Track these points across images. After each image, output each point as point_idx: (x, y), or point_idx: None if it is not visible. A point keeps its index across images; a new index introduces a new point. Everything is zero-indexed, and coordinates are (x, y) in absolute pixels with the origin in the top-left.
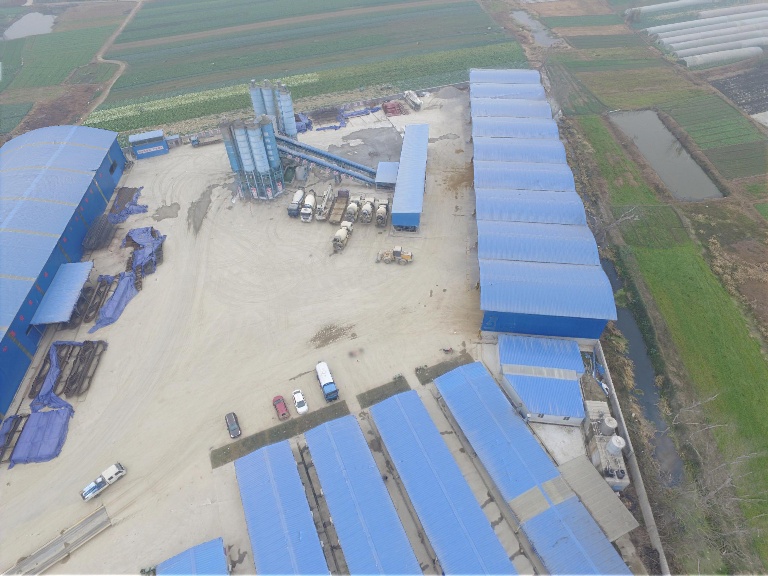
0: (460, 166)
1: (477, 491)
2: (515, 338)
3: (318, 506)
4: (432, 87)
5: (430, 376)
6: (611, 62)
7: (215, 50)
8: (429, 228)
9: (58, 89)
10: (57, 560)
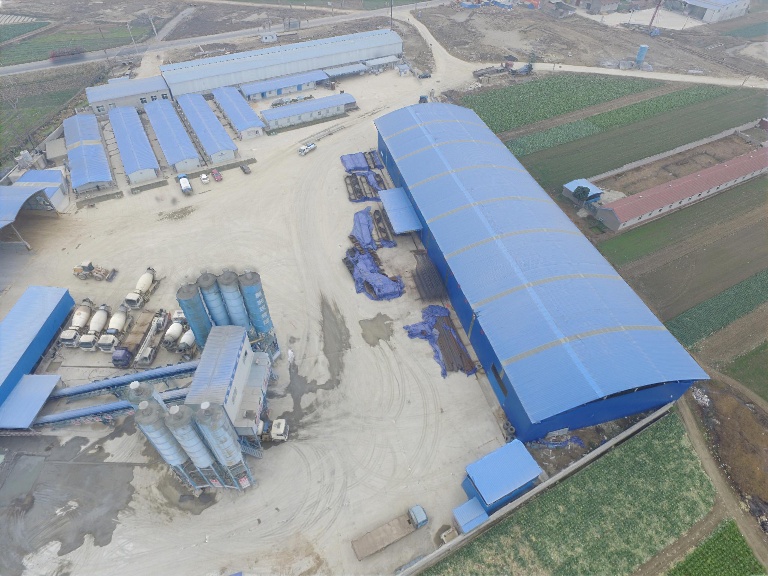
0: None
1: (116, 157)
2: None
3: (199, 151)
4: None
5: (114, 195)
6: None
7: None
8: None
9: None
10: None
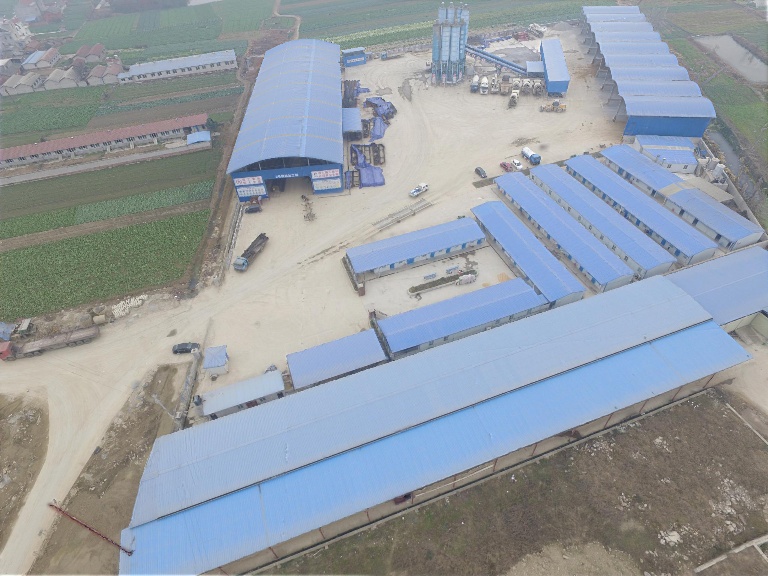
0: (584, 66)
1: None
2: (647, 136)
3: None
4: (549, 23)
5: (593, 156)
6: (691, 6)
7: (365, 7)
8: (571, 96)
9: (259, 32)
10: (410, 214)
